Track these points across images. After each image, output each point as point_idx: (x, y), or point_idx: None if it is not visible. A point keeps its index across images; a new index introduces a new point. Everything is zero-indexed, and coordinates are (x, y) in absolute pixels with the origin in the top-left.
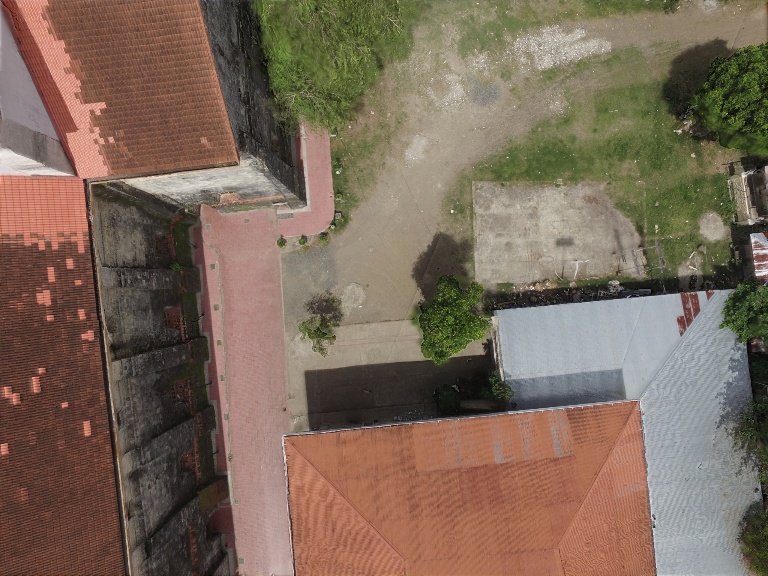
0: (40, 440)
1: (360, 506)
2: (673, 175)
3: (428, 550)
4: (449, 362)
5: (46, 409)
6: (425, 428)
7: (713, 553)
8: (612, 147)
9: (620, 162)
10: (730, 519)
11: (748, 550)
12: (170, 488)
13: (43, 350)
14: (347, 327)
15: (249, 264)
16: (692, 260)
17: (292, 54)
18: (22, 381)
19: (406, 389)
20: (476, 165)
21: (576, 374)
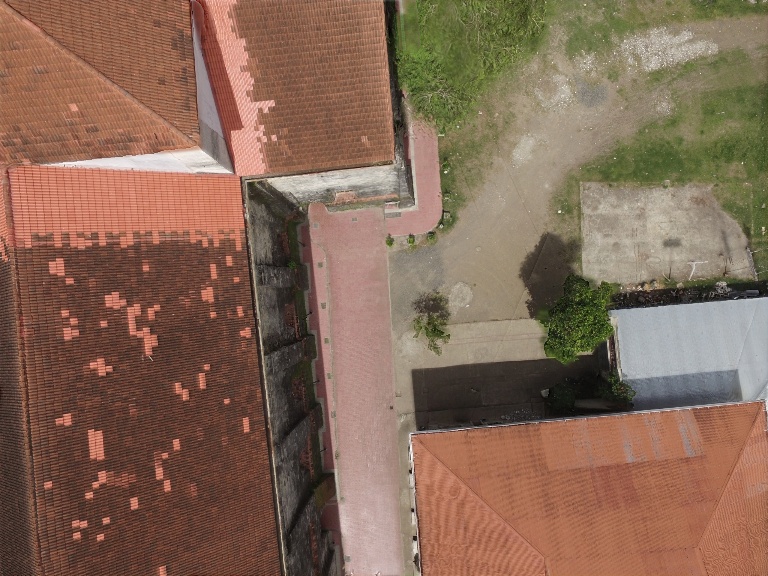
0: (207, 436)
1: (495, 504)
2: None
3: (568, 548)
4: (556, 362)
5: (211, 405)
6: (553, 427)
7: None
8: (719, 149)
9: (727, 164)
10: None
11: None
12: (296, 485)
13: (208, 347)
14: (454, 326)
15: (356, 263)
16: None
17: (440, 54)
18: (191, 377)
19: (513, 388)
20: (583, 166)
21: (692, 374)
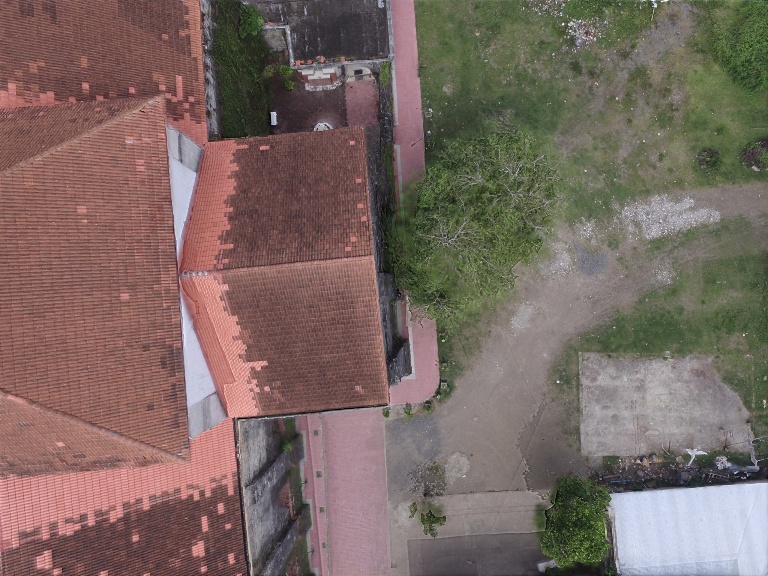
0: None
1: None
2: None
3: None
4: None
5: None
6: None
7: None
8: (720, 319)
9: (728, 335)
10: None
11: None
12: None
13: None
14: (451, 497)
15: (353, 431)
16: None
17: (436, 282)
18: None
19: (509, 561)
20: (583, 335)
21: (690, 564)
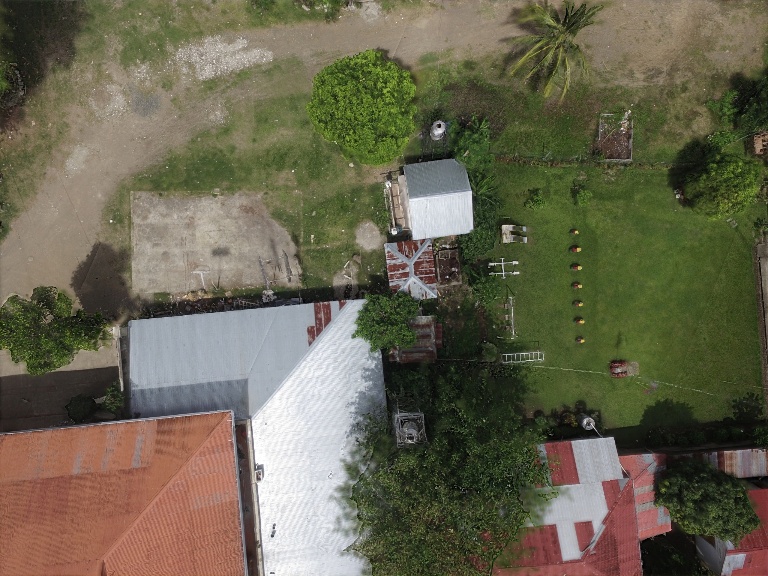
0: None
1: None
2: (331, 184)
3: None
4: (106, 371)
5: None
6: (16, 439)
7: (339, 562)
8: (271, 157)
9: (278, 172)
10: (358, 528)
11: None
12: None
13: None
14: None
15: None
16: (347, 269)
17: None
18: None
19: (64, 398)
20: (136, 175)
21: (202, 384)
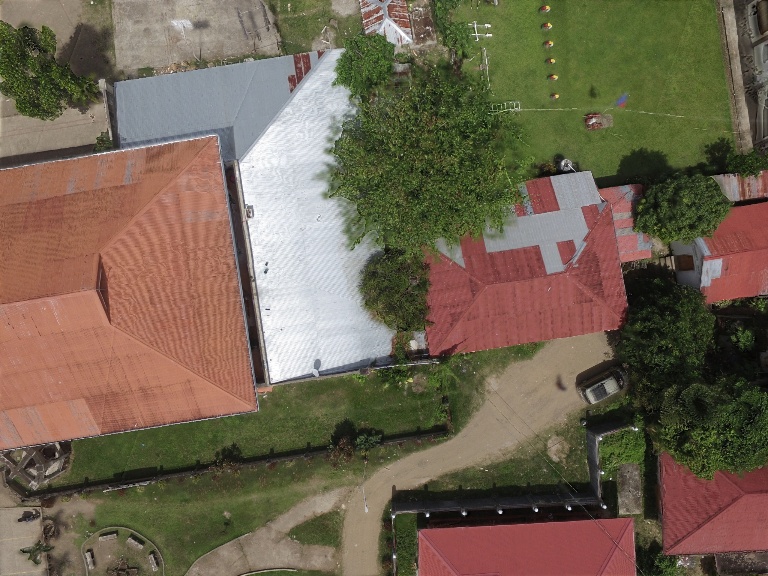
0: None
1: None
2: None
3: None
4: None
5: None
6: (9, 173)
7: (332, 299)
8: None
9: None
10: (349, 266)
11: (361, 291)
12: None
13: None
14: None
15: None
16: (325, 35)
17: None
18: None
19: None
20: None
21: (189, 134)
